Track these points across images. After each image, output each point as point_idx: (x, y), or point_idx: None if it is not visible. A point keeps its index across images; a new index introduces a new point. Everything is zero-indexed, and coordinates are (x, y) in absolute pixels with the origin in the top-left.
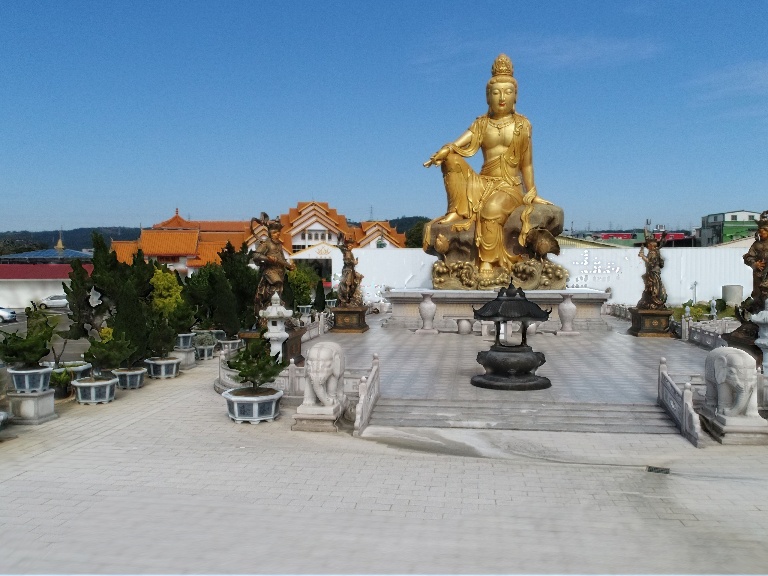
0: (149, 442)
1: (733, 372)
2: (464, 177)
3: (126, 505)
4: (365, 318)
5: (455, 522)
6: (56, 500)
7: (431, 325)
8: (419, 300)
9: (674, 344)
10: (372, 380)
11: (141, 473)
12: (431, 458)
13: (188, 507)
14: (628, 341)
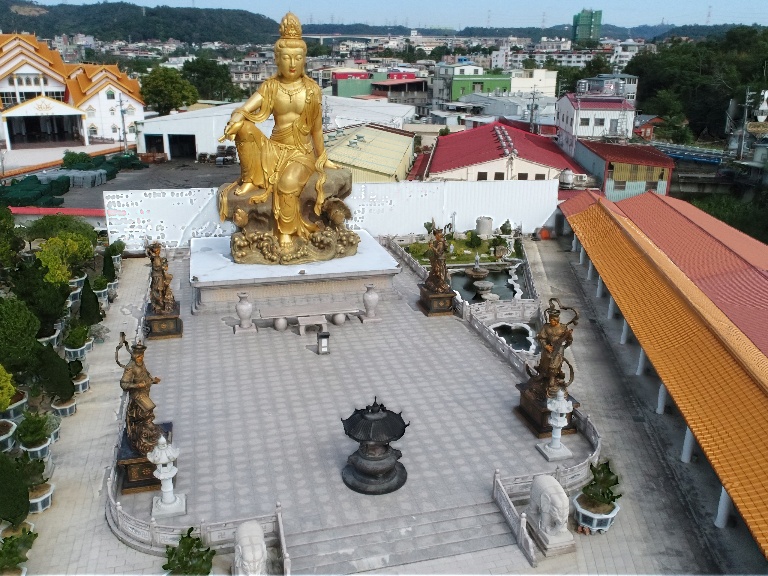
0: None
1: (555, 511)
2: (258, 146)
3: None
4: None
5: None
6: None
7: (249, 323)
8: (228, 286)
9: (461, 335)
10: None
11: None
12: None
13: None
14: (425, 332)
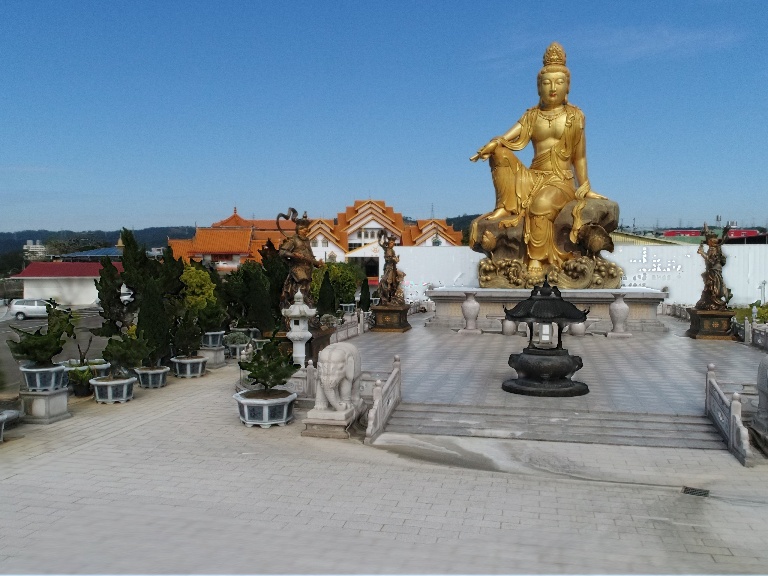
0: (151, 445)
1: None
2: (512, 171)
3: (102, 515)
4: (411, 317)
5: (449, 548)
6: (33, 507)
7: (474, 325)
8: (463, 299)
9: (735, 348)
10: (391, 384)
11: (131, 479)
12: (442, 471)
13: (165, 520)
14: (684, 344)
